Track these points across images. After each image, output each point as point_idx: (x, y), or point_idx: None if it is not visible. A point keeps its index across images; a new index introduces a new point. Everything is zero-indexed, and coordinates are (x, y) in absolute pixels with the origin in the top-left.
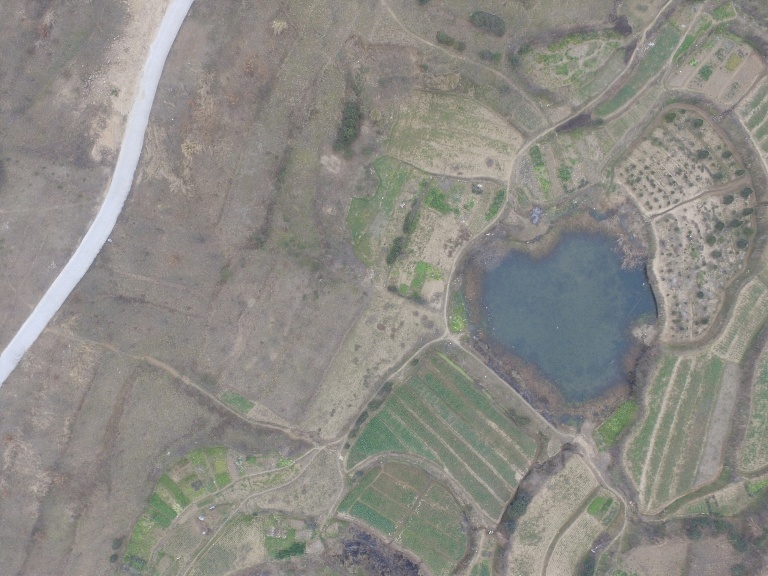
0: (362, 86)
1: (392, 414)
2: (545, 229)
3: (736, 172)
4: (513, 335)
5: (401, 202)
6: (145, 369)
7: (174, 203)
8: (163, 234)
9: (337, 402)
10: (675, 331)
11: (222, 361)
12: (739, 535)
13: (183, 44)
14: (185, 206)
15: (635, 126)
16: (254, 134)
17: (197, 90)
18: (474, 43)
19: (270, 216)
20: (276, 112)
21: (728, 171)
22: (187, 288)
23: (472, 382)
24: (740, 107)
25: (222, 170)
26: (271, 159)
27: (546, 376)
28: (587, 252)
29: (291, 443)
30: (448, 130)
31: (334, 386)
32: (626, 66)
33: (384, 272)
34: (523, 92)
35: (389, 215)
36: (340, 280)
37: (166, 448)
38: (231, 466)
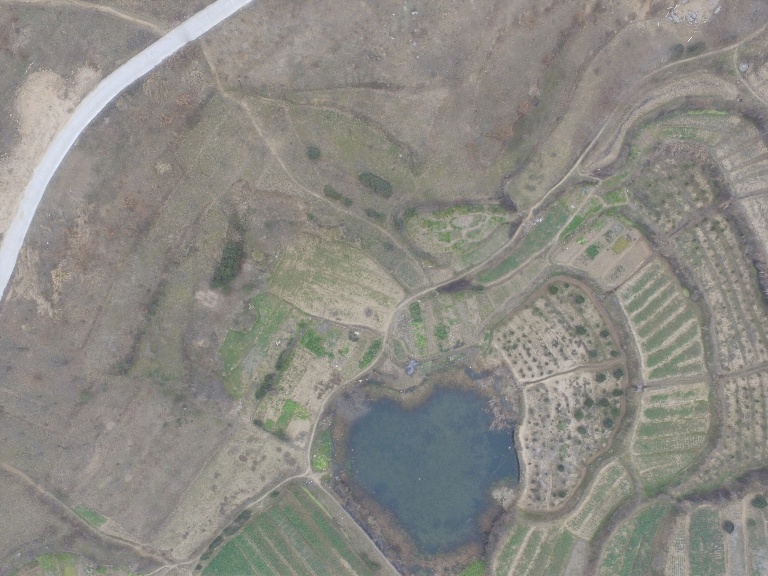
0: (248, 226)
1: (249, 540)
2: (419, 381)
3: (611, 353)
4: (376, 479)
5: (277, 340)
6: (1, 473)
7: (40, 324)
8: (27, 351)
9: (191, 526)
10: (532, 500)
11: (76, 477)
12: None
13: (66, 172)
14: (51, 328)
15: (516, 295)
16: (129, 265)
17: (74, 218)
18: (361, 200)
19: (138, 345)
20: (153, 247)
21: (604, 350)
22: (46, 405)
23: (331, 519)
24: (622, 290)
25: (92, 298)
26: (143, 291)
27: (402, 525)
28: (459, 408)
29: (141, 560)
30: (332, 275)
31: (190, 510)
32: (510, 240)
33: (252, 405)
34: (407, 251)
35: (264, 351)
36: (204, 411)
37: (16, 549)
38: (81, 573)
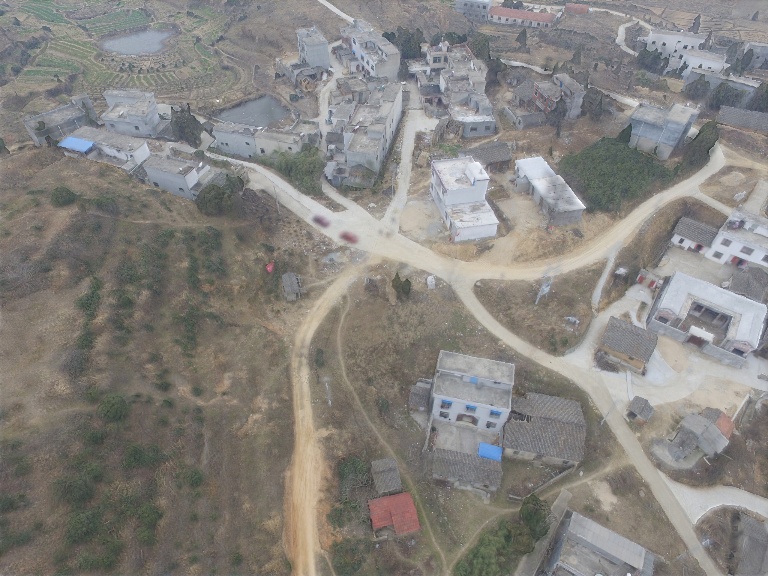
0: (245, 6)
1: None
2: (171, 42)
3: None
4: None
5: None
6: None
7: None
8: None
9: (154, 4)
10: None
11: None
12: (22, 44)
13: None
14: None
15: None
16: None
17: None
18: None
19: None
20: None
21: None
22: None
23: None
24: None
25: None
26: None
27: (121, 37)
28: None
29: None
30: None
31: None
32: None
33: None
34: None
35: None
36: None
37: None
38: None
